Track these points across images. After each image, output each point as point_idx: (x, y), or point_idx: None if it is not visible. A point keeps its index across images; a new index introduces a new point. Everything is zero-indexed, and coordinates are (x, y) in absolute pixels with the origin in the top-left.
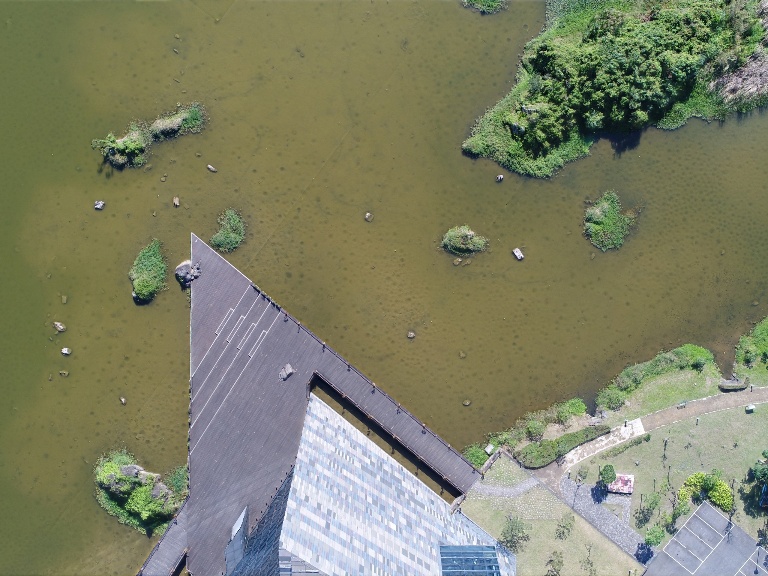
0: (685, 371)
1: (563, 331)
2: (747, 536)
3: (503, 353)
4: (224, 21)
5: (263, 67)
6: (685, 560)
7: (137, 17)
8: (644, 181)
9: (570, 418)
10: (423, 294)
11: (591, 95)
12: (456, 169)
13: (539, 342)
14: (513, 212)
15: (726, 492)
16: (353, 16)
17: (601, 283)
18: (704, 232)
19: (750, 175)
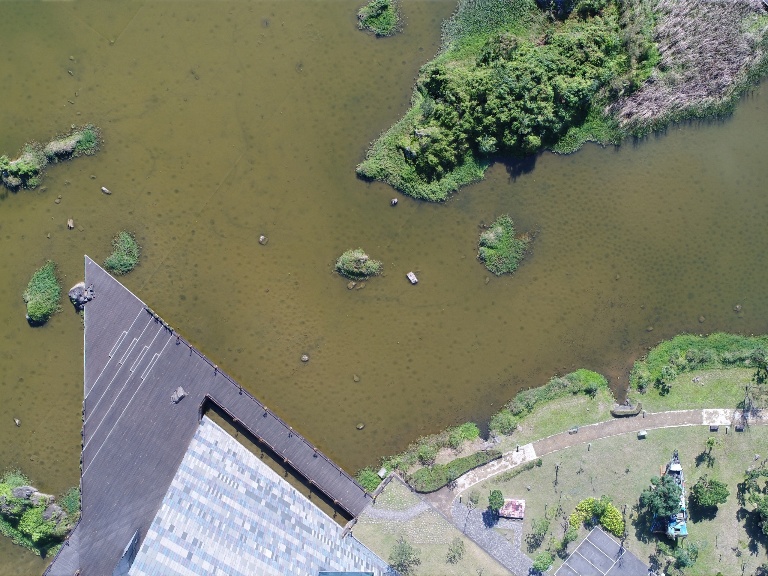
0: (578, 396)
1: (457, 355)
2: (638, 561)
3: (397, 377)
4: (119, 43)
5: (158, 89)
6: None
7: (32, 38)
8: (539, 205)
9: (461, 443)
10: (317, 317)
11: (482, 120)
12: (351, 192)
13: (433, 366)
14: (408, 236)
15: (617, 518)
16: (248, 38)
17: (495, 307)
18: (599, 257)
19: (645, 200)
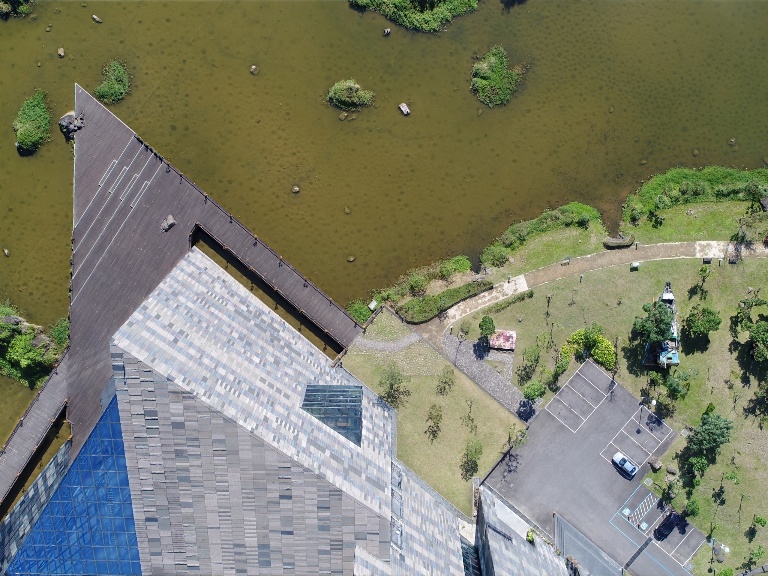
0: (570, 228)
1: (449, 188)
2: (630, 395)
3: (388, 209)
4: None
5: None
6: (567, 418)
7: None
8: (533, 37)
9: (452, 272)
10: (308, 149)
11: None
12: (343, 23)
13: (425, 198)
14: (400, 67)
15: (608, 349)
16: None
17: (488, 140)
18: (593, 89)
19: (640, 32)
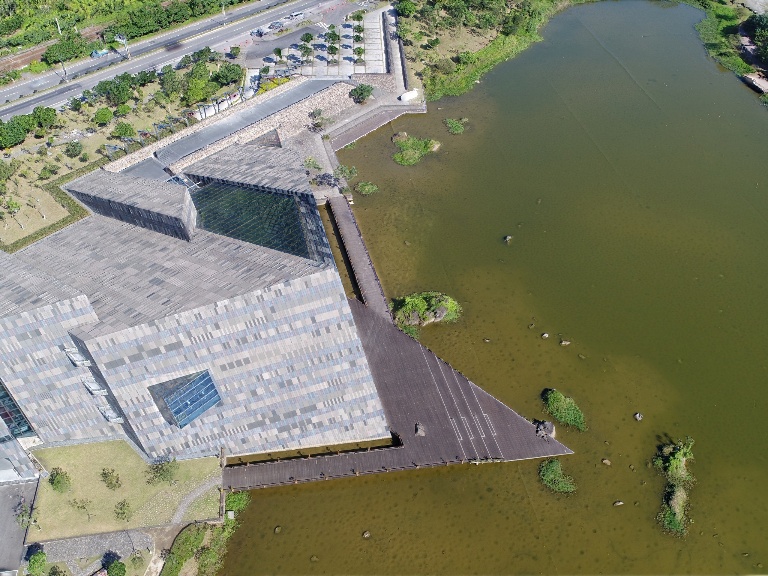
0: None
1: None
2: None
3: None
4: None
5: None
6: None
7: None
8: None
9: None
10: (390, 571)
11: None
12: None
13: None
14: None
15: None
16: None
17: None
18: None
19: None
